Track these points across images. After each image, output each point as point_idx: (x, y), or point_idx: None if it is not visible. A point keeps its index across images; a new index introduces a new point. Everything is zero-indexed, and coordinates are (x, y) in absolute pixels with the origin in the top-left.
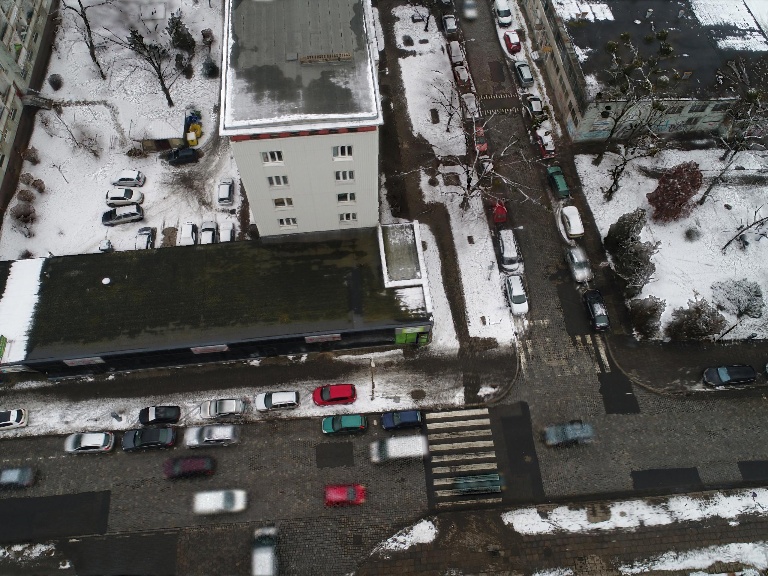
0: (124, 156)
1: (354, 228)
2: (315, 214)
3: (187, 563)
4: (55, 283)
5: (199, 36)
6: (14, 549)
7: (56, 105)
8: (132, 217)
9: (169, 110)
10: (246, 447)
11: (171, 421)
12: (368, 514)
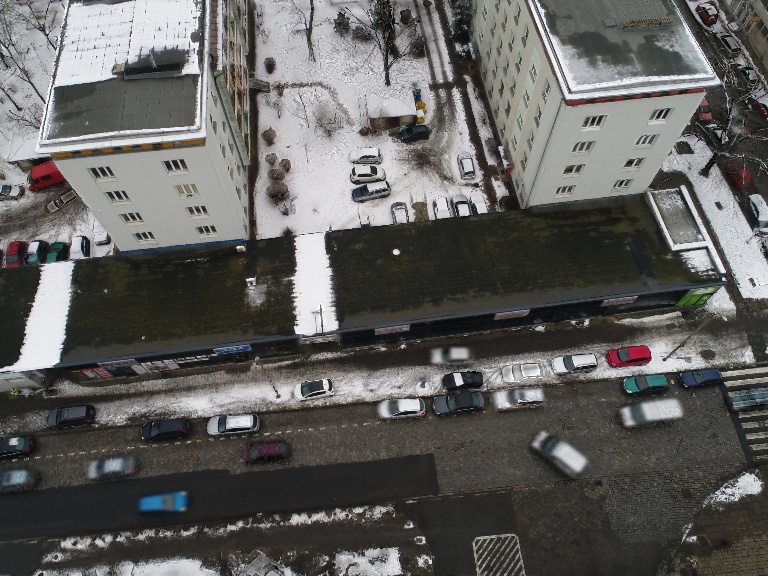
0: (355, 135)
1: (622, 195)
2: (596, 181)
3: (527, 520)
4: (343, 256)
5: (395, 17)
6: (355, 511)
7: (279, 87)
8: (382, 193)
9: None
10: (553, 409)
11: (476, 386)
12: (690, 469)
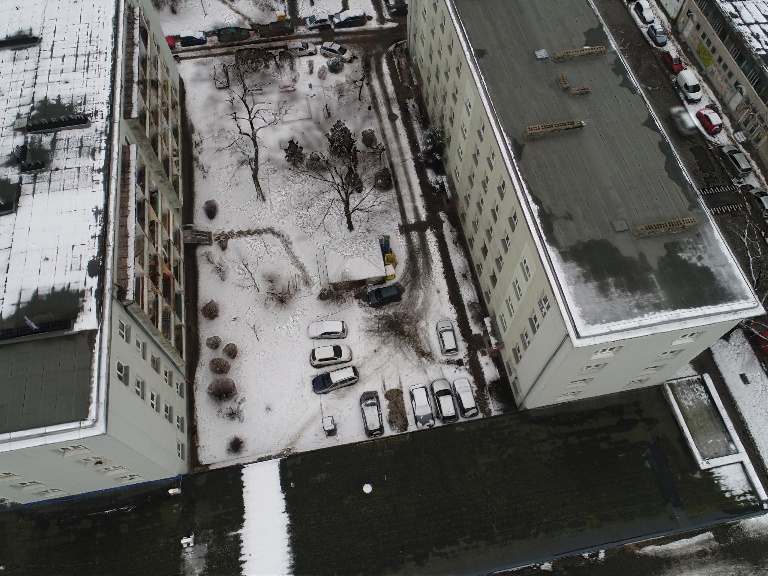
0: (314, 299)
1: (634, 389)
2: (605, 385)
3: None
4: (302, 494)
5: (356, 137)
6: None
7: (222, 241)
8: (349, 382)
9: (351, 236)
10: None
11: None
12: None
